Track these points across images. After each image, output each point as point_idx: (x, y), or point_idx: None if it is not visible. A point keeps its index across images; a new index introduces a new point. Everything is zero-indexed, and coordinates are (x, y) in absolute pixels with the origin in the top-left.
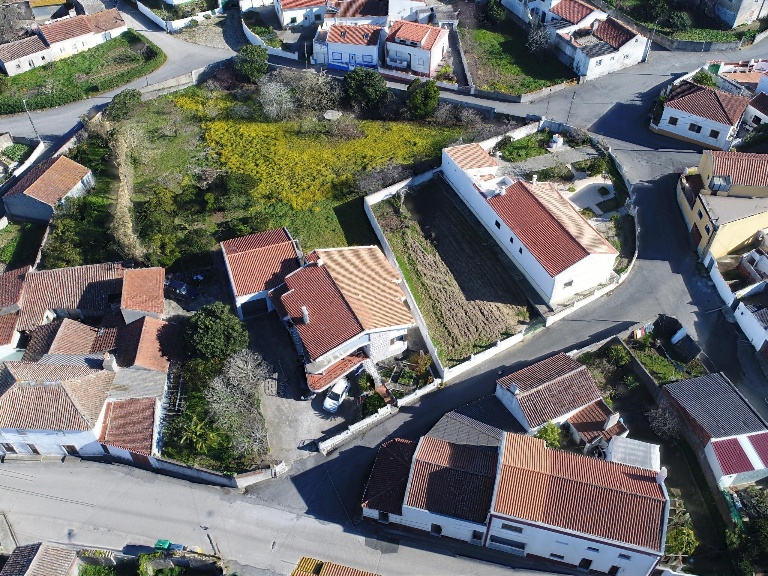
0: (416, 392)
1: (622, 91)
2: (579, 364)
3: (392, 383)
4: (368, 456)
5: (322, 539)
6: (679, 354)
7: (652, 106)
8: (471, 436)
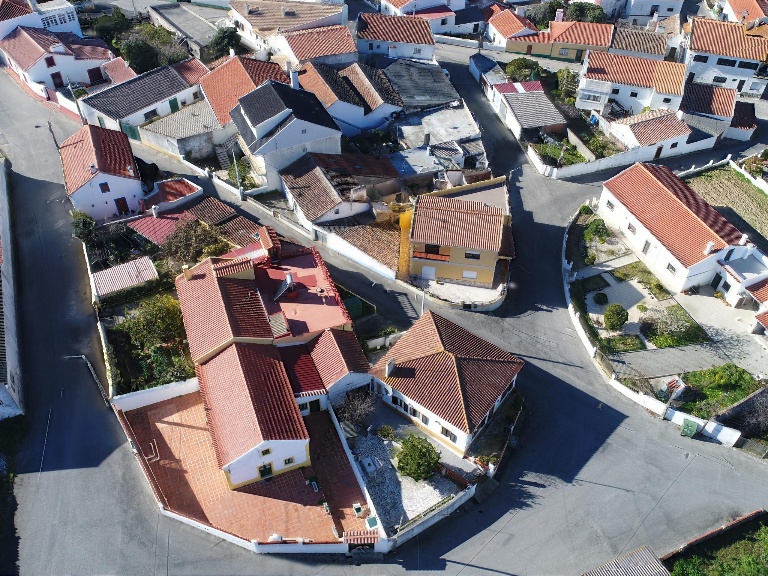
0: (746, 158)
1: (559, 517)
2: (633, 128)
3: (767, 170)
4: (761, 140)
5: (767, 114)
6: (542, 157)
7: (506, 467)
8: (699, 119)
